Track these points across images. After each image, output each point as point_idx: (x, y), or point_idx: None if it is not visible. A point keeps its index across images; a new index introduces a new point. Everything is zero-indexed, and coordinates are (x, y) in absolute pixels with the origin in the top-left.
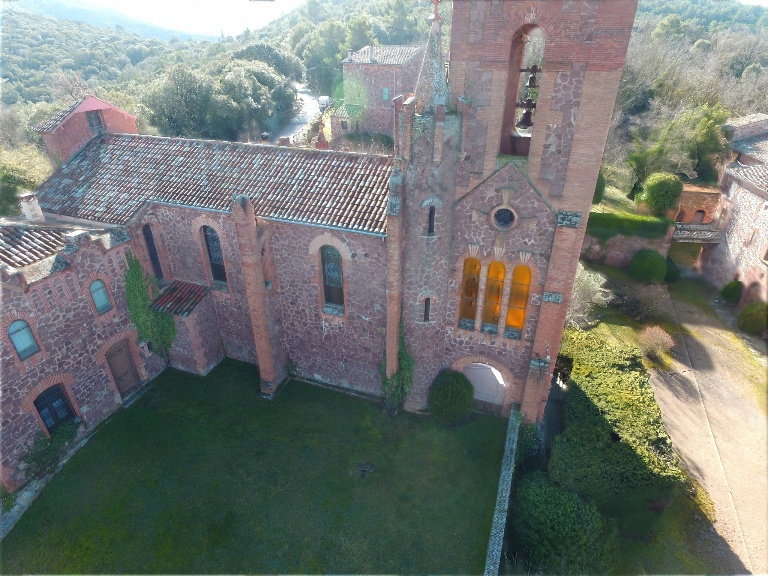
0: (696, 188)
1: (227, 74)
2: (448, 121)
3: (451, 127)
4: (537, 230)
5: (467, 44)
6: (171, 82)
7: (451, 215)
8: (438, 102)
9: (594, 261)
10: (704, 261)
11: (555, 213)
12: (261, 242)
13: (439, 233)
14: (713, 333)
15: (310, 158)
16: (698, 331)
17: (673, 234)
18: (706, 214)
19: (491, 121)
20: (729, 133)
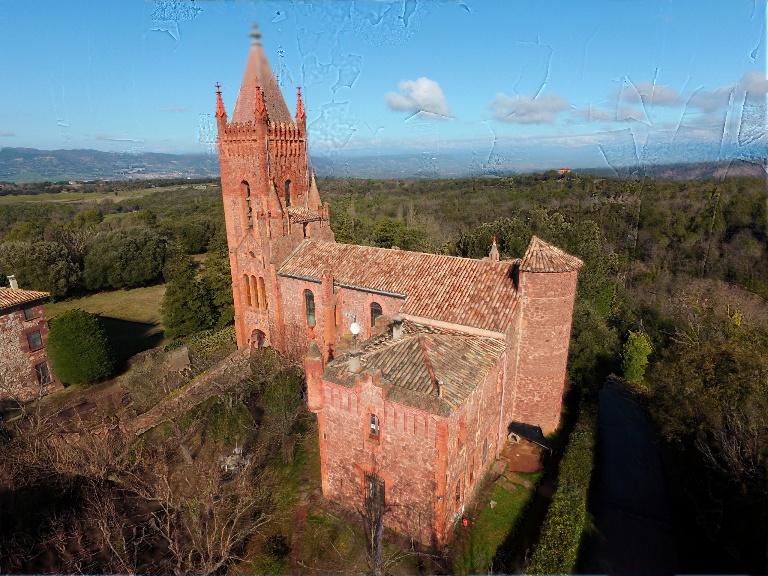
0: None
1: None
2: None
3: None
4: None
5: None
6: None
7: None
8: None
9: None
10: None
11: None
12: None
13: None
14: None
15: None
16: None
17: None
18: None
19: None
20: None
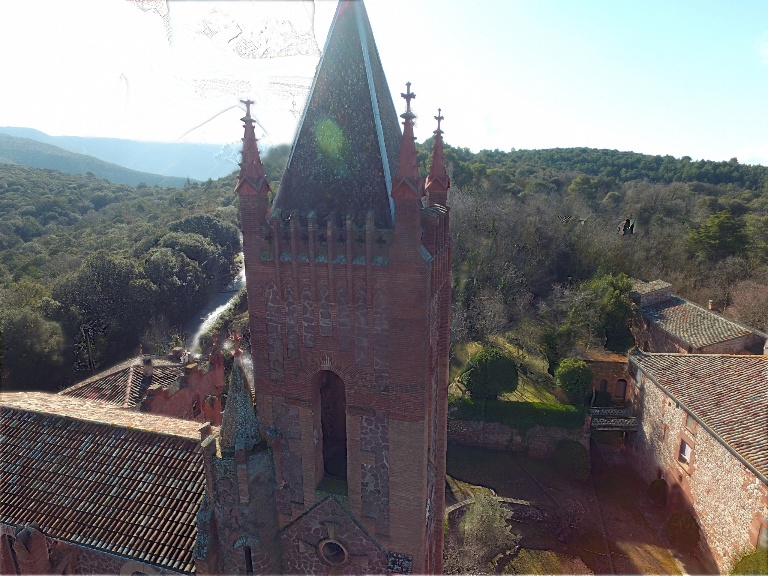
0: (614, 356)
1: (153, 255)
2: (253, 460)
3: (258, 465)
4: (370, 569)
5: (270, 380)
6: (88, 269)
7: (275, 547)
8: (237, 446)
9: (517, 453)
10: (628, 446)
11: (385, 554)
12: (58, 572)
13: (260, 572)
14: (643, 551)
15: (144, 443)
16: (627, 549)
17: (591, 422)
18: (627, 383)
19: (304, 454)
20: (636, 300)
